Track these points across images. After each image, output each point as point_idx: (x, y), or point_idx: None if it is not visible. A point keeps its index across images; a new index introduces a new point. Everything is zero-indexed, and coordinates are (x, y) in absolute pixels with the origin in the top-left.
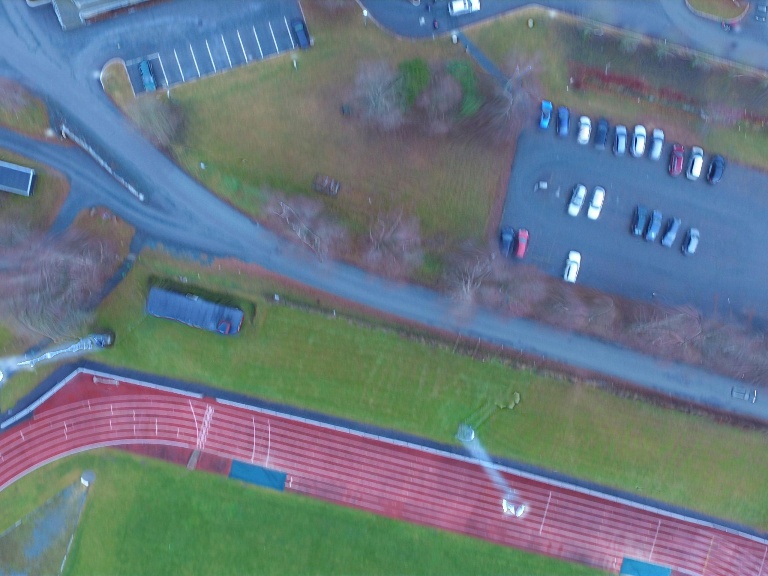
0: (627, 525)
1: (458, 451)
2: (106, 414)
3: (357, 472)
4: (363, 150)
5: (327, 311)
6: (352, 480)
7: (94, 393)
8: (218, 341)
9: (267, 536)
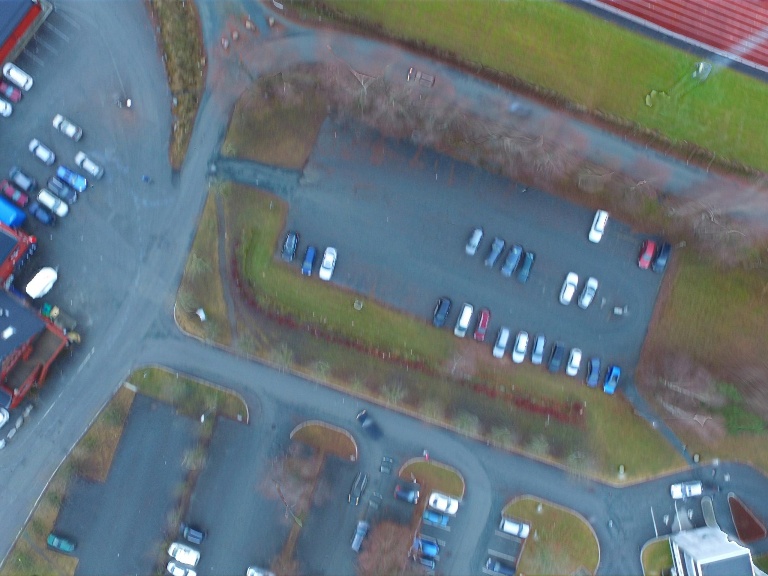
0: None
1: (705, 54)
2: None
3: None
4: None
5: None
6: None
7: None
8: None
9: None
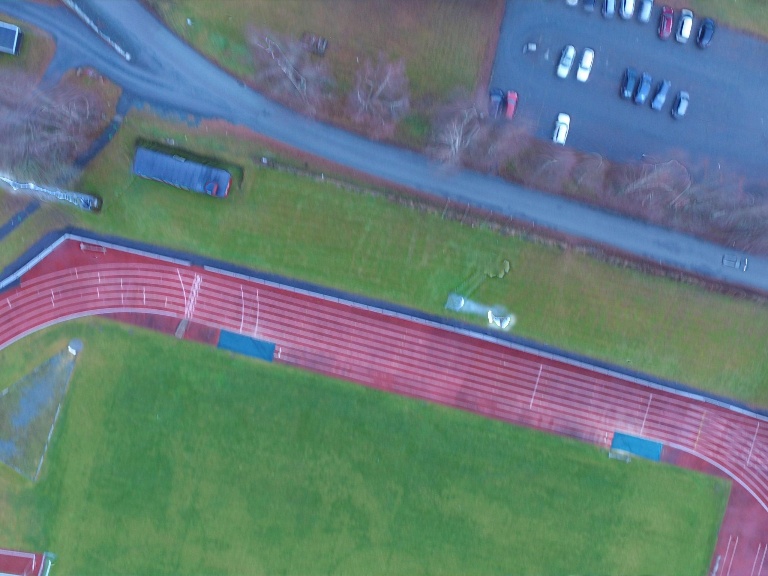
0: (618, 399)
1: (448, 322)
2: (93, 282)
3: (346, 343)
4: (351, 8)
5: (315, 174)
6: (341, 351)
7: (81, 261)
8: (206, 207)
9: (256, 407)
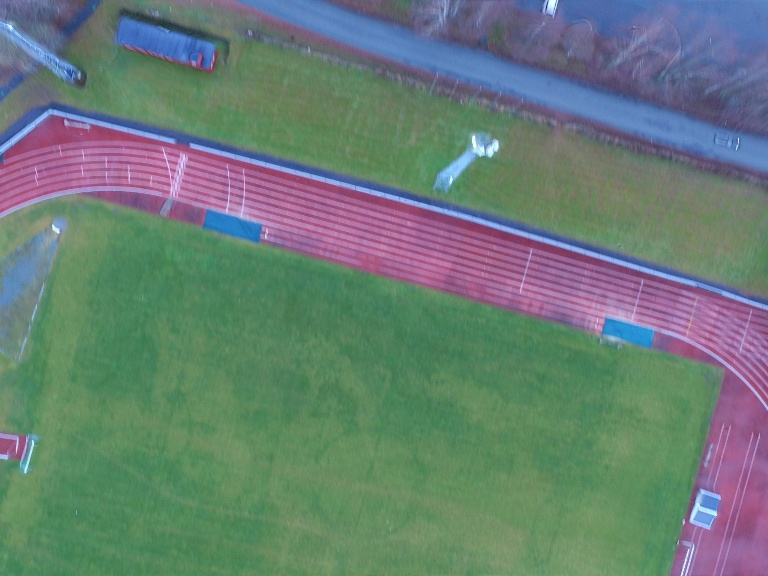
0: (609, 284)
1: (436, 204)
2: (77, 160)
3: (334, 225)
4: None
5: (301, 46)
6: (329, 233)
7: (65, 138)
8: (191, 82)
9: (242, 288)
